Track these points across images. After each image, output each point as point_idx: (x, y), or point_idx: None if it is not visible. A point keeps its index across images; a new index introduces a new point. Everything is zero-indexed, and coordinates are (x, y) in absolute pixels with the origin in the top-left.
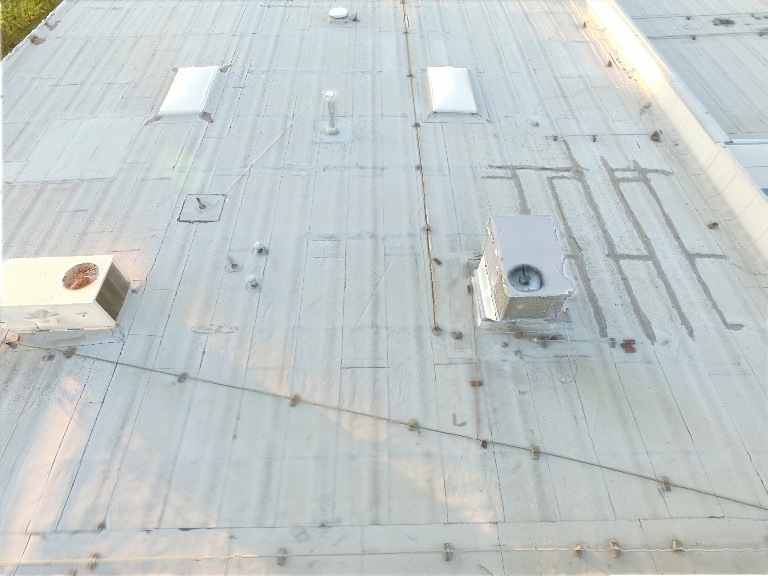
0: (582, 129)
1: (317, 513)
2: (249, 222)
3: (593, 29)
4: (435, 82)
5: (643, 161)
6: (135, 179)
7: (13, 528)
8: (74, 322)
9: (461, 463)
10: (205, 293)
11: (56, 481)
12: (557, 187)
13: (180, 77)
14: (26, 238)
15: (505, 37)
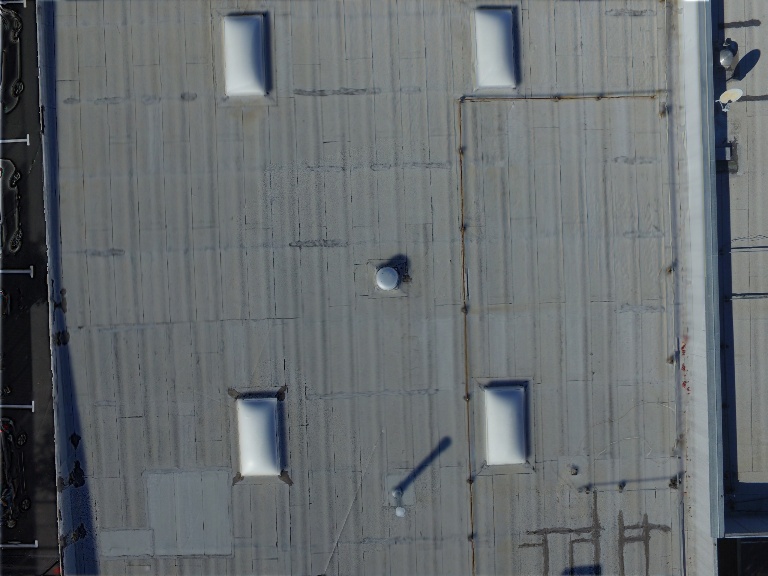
0: (614, 474)
1: None
2: None
3: (677, 279)
4: (491, 420)
5: (652, 515)
6: (250, 558)
7: None
8: None
9: None
10: None
11: None
12: (575, 552)
13: (244, 421)
14: None
15: (573, 308)
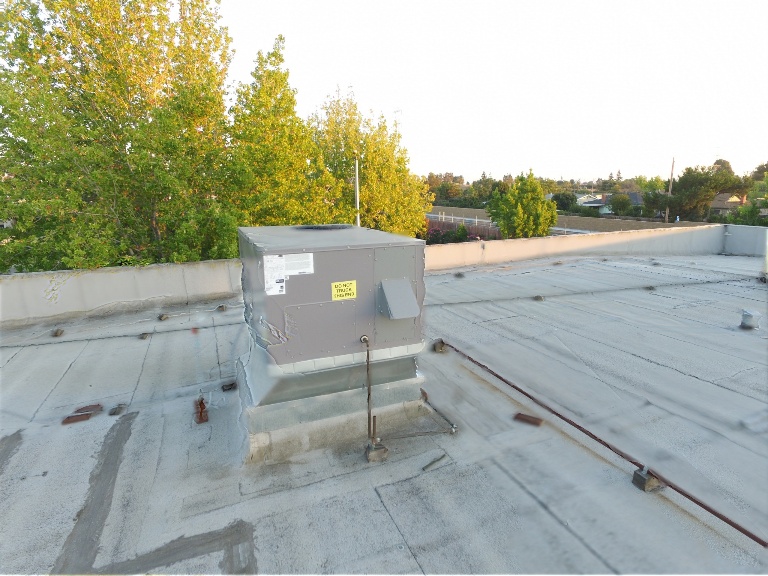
0: None
1: None
2: None
3: None
4: None
5: None
6: None
7: None
8: None
9: None
10: None
11: None
12: None
13: None
14: None
15: None
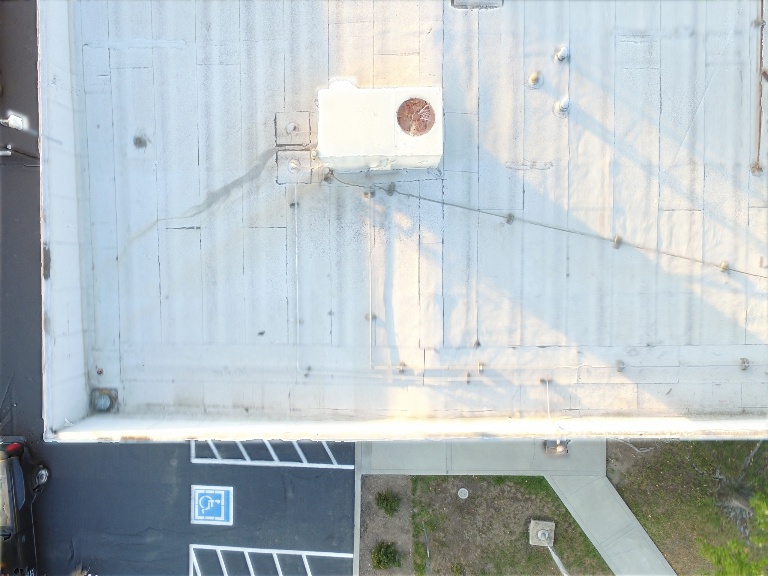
0: None
1: (643, 336)
2: (541, 9)
3: None
4: None
5: None
6: None
7: (407, 344)
8: (404, 165)
9: (762, 300)
10: (510, 119)
11: (429, 311)
12: None
13: None
14: (268, 29)
15: None
